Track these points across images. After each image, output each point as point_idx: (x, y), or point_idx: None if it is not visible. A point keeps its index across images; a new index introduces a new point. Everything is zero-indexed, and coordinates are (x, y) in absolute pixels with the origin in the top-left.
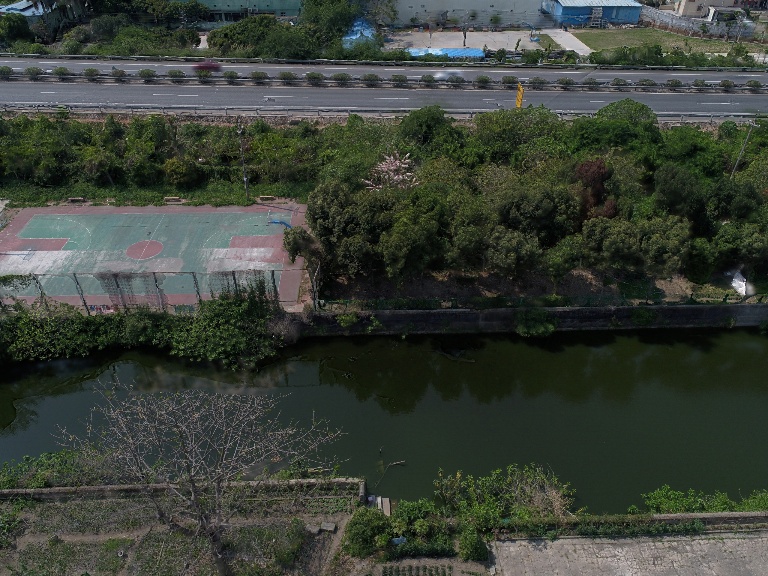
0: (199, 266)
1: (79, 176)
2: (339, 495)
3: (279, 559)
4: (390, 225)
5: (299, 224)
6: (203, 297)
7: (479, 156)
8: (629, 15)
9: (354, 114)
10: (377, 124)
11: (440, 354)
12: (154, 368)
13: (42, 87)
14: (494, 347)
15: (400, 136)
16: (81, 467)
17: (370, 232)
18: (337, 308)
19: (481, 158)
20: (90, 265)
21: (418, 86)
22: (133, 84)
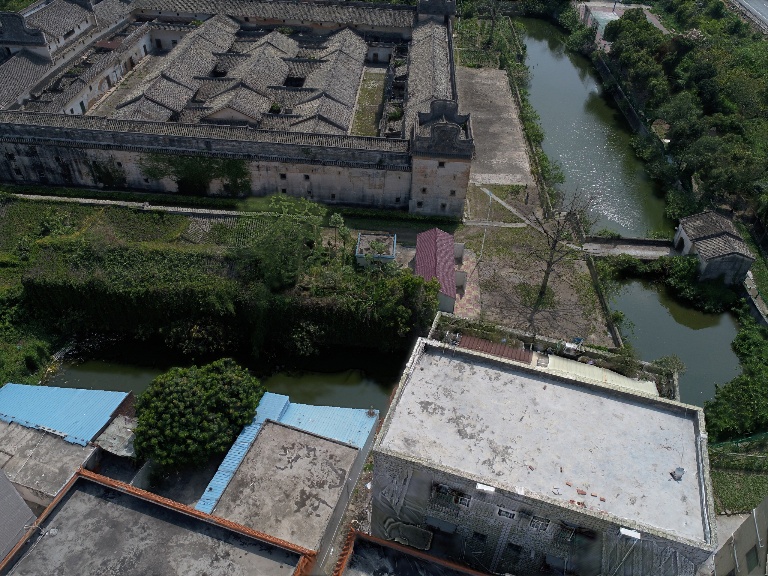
0: None
1: None
2: None
3: None
4: None
5: None
6: None
7: None
8: None
9: None
10: None
11: None
12: None
13: None
14: None
15: (767, 55)
16: None
17: None
18: None
19: None
20: None
21: None
22: None
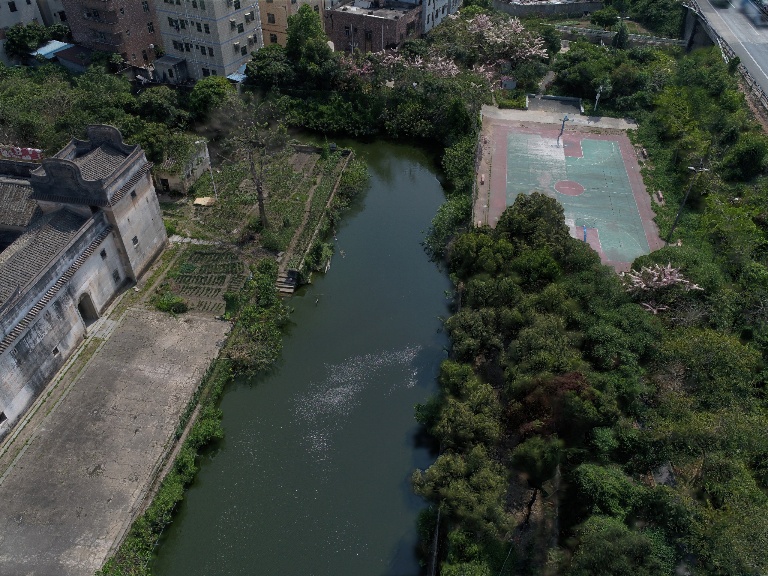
0: None
1: None
2: None
3: None
4: None
5: (627, 268)
6: None
7: None
8: None
9: None
10: None
11: None
12: None
13: None
14: (425, 387)
15: None
16: None
17: None
18: None
19: None
20: (545, 168)
21: None
22: None
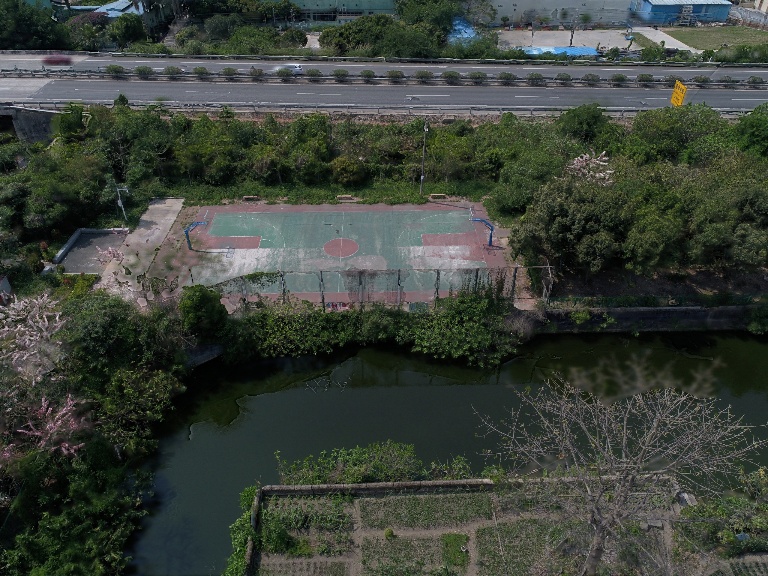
0: (403, 264)
1: (246, 175)
2: (651, 492)
3: (624, 555)
4: (632, 222)
5: None
6: (422, 294)
7: (645, 154)
8: (718, 13)
9: (509, 112)
10: (529, 122)
11: (659, 352)
12: (383, 365)
13: (184, 86)
14: (726, 345)
15: (559, 134)
16: (390, 463)
17: (612, 229)
18: (560, 306)
19: (647, 156)
20: (295, 263)
21: (553, 84)
22: (271, 83)
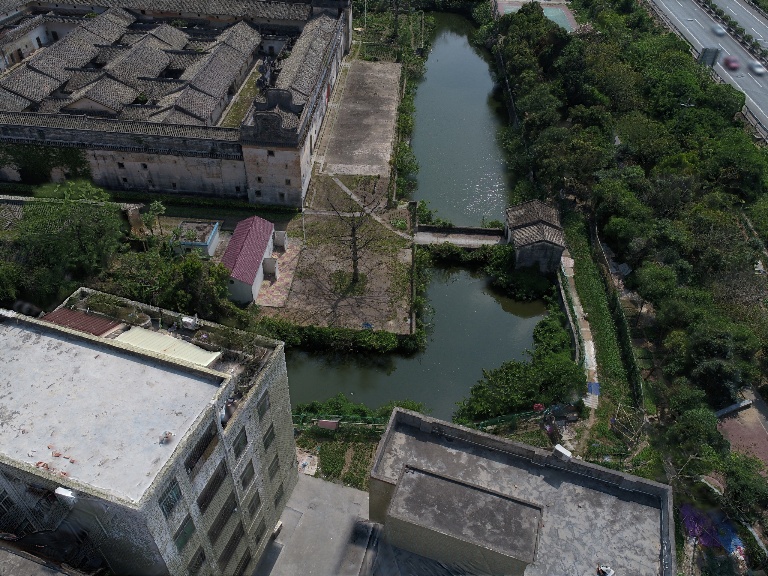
0: None
1: None
2: None
3: None
4: None
5: None
6: None
7: None
8: None
9: None
10: None
11: None
12: None
13: None
14: None
15: None
16: None
17: None
18: None
19: None
20: None
21: None
22: None
